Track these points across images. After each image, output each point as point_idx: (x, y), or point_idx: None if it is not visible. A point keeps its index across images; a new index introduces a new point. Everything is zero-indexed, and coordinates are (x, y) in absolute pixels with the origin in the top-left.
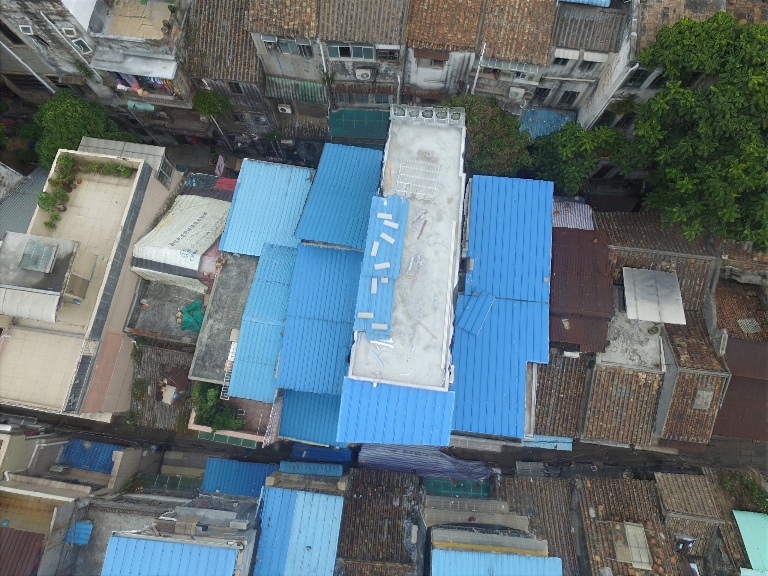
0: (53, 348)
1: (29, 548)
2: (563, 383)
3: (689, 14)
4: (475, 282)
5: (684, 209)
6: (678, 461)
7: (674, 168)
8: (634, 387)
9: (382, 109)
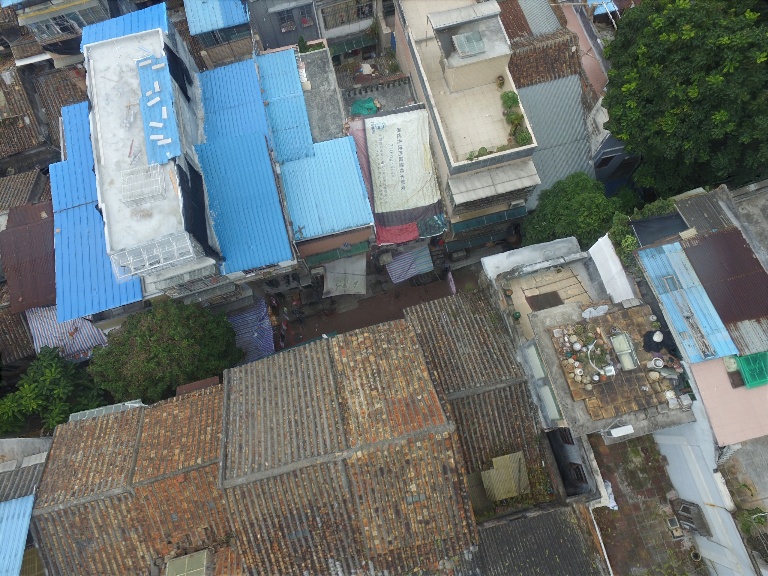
0: None
1: None
2: None
3: None
4: None
5: None
6: None
7: None
8: None
9: None
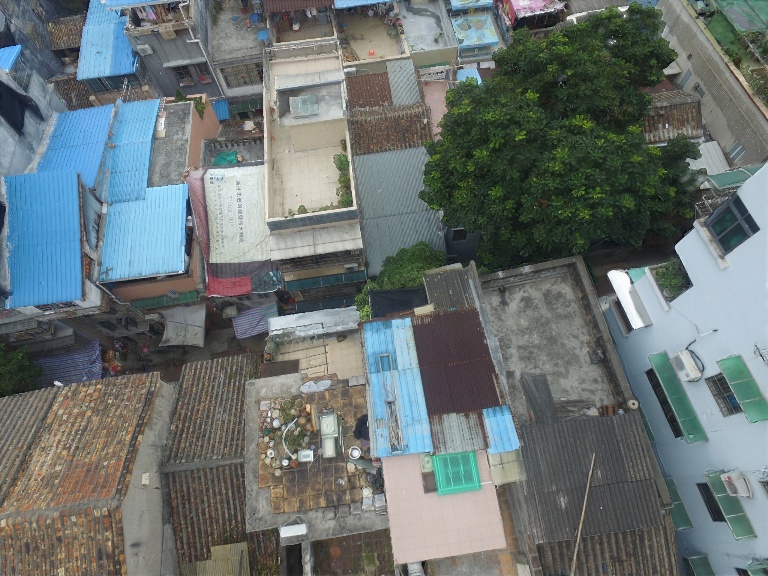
0: None
1: (269, 5)
2: None
3: None
4: None
5: None
6: None
7: None
8: None
9: None
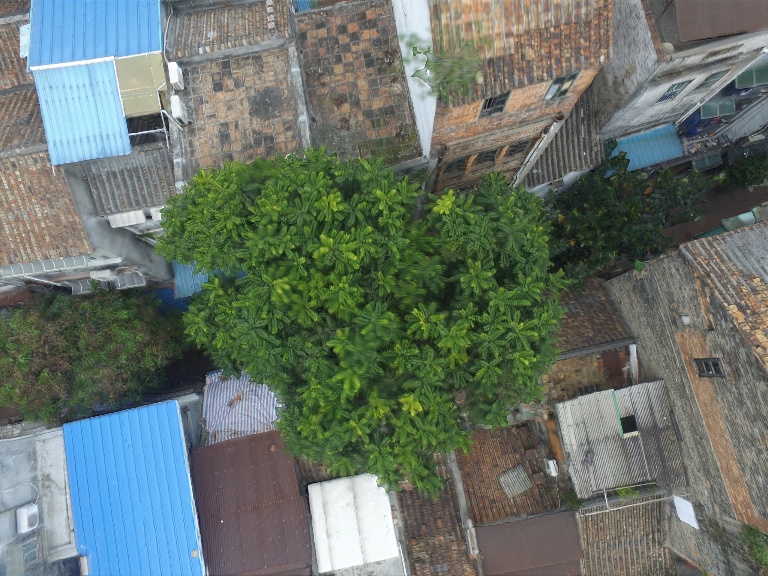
0: None
1: None
2: None
3: (258, 124)
4: None
5: None
6: None
7: None
8: None
9: None
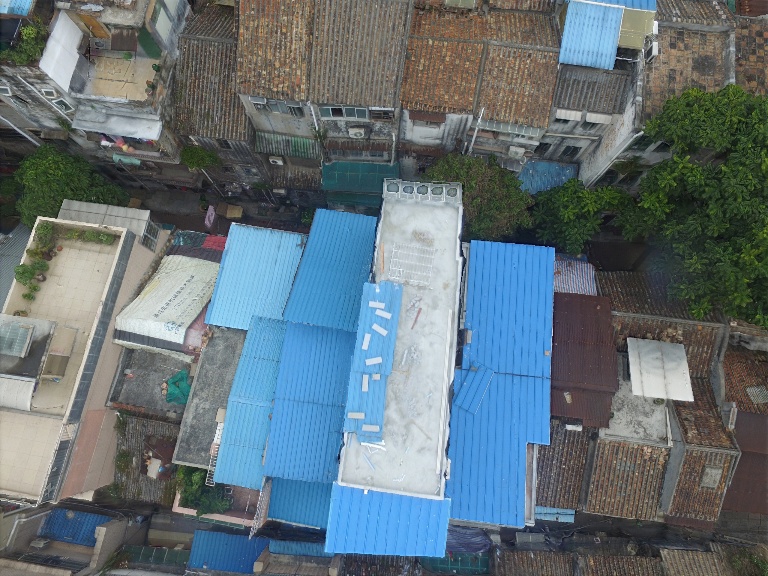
0: (30, 430)
1: None
2: (565, 454)
3: (697, 77)
4: (473, 355)
5: (692, 287)
6: (684, 532)
7: (682, 243)
8: (639, 461)
9: (377, 162)
